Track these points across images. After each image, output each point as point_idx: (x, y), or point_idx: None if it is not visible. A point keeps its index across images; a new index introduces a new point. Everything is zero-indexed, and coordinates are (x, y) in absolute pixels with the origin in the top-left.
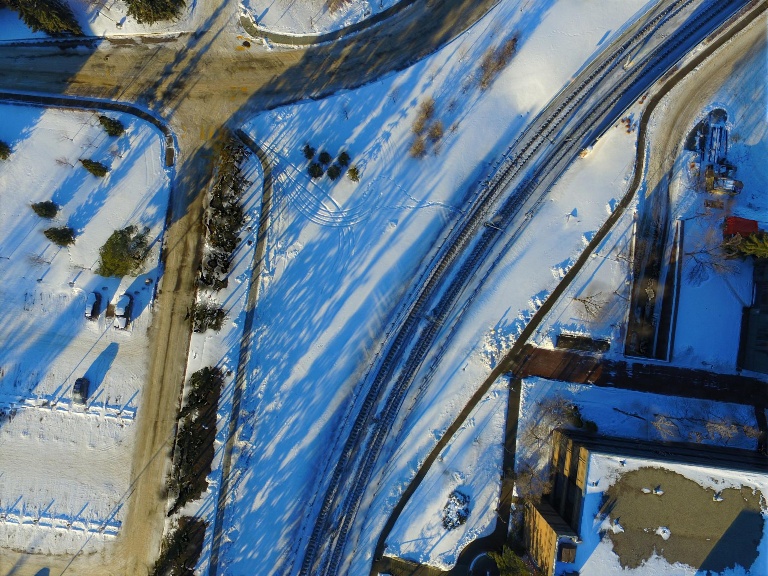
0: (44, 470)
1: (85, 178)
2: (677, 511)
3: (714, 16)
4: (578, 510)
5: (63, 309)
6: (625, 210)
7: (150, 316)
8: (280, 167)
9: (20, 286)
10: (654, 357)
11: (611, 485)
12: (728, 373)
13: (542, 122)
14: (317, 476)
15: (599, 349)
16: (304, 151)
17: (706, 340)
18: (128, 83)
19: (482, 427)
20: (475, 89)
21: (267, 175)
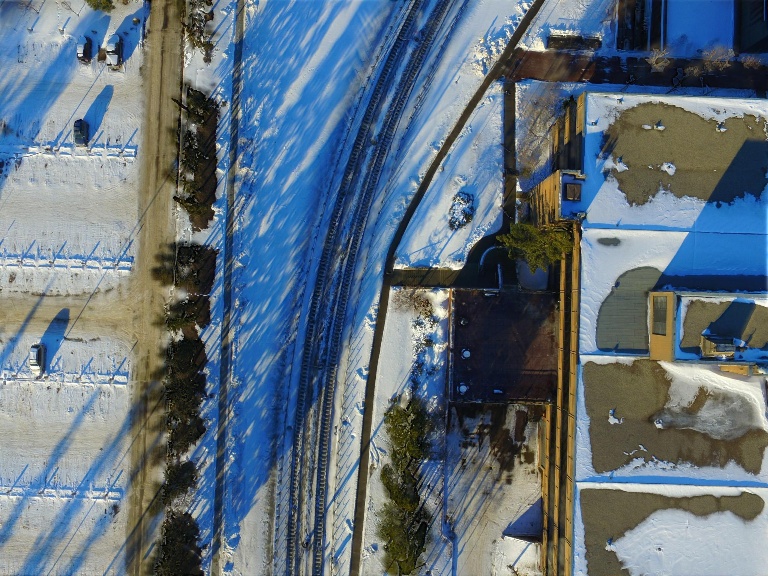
0: (54, 213)
1: None
2: (680, 145)
3: None
4: (580, 153)
5: (56, 57)
6: None
7: (141, 56)
8: None
9: (12, 38)
10: None
11: (611, 124)
12: None
13: None
14: (321, 198)
15: (591, 47)
16: None
17: (699, 27)
18: None
19: (480, 132)
20: None
21: None
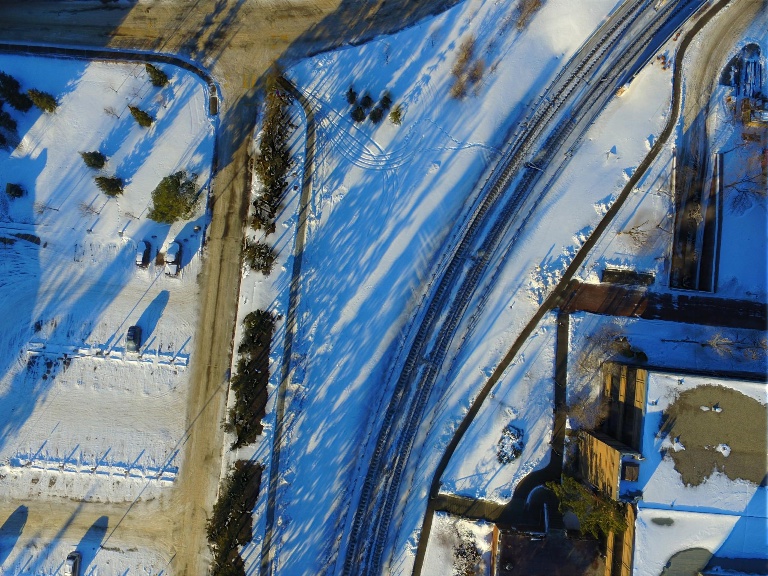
0: (100, 418)
1: (131, 129)
2: (736, 428)
3: None
4: (639, 430)
5: (113, 259)
6: (664, 145)
7: (199, 263)
8: (322, 113)
9: (70, 237)
10: (698, 289)
11: (670, 404)
12: None
13: (577, 63)
14: (370, 417)
15: (644, 282)
16: (347, 95)
17: (750, 270)
18: (170, 34)
19: (532, 362)
20: (512, 31)
21: (310, 121)
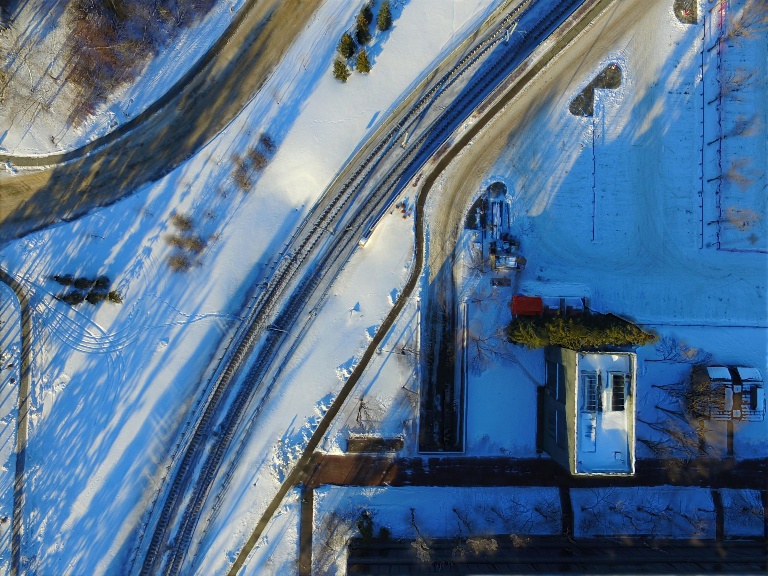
0: None
1: None
2: None
3: (493, 81)
4: None
5: None
6: (408, 299)
7: None
8: (37, 297)
9: None
10: (452, 448)
11: None
12: (529, 456)
13: (320, 213)
14: None
15: (392, 448)
16: (56, 280)
17: (502, 426)
18: None
19: (275, 544)
20: (237, 191)
21: (24, 307)
